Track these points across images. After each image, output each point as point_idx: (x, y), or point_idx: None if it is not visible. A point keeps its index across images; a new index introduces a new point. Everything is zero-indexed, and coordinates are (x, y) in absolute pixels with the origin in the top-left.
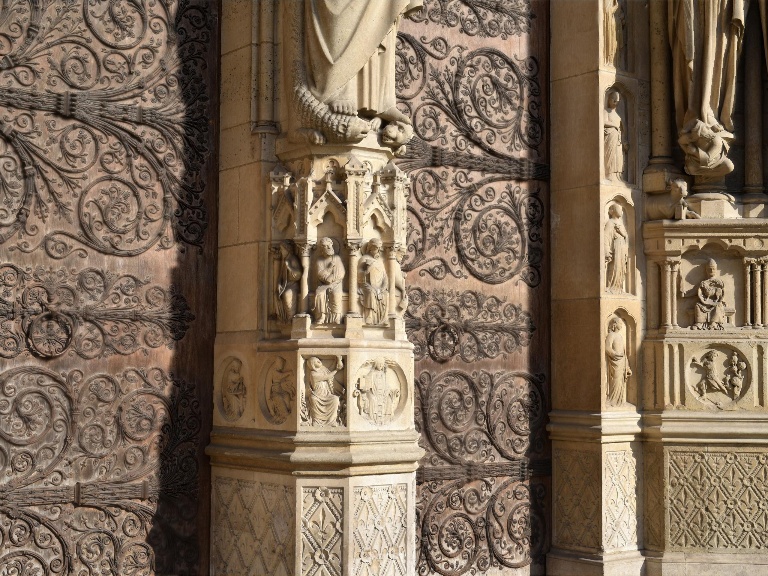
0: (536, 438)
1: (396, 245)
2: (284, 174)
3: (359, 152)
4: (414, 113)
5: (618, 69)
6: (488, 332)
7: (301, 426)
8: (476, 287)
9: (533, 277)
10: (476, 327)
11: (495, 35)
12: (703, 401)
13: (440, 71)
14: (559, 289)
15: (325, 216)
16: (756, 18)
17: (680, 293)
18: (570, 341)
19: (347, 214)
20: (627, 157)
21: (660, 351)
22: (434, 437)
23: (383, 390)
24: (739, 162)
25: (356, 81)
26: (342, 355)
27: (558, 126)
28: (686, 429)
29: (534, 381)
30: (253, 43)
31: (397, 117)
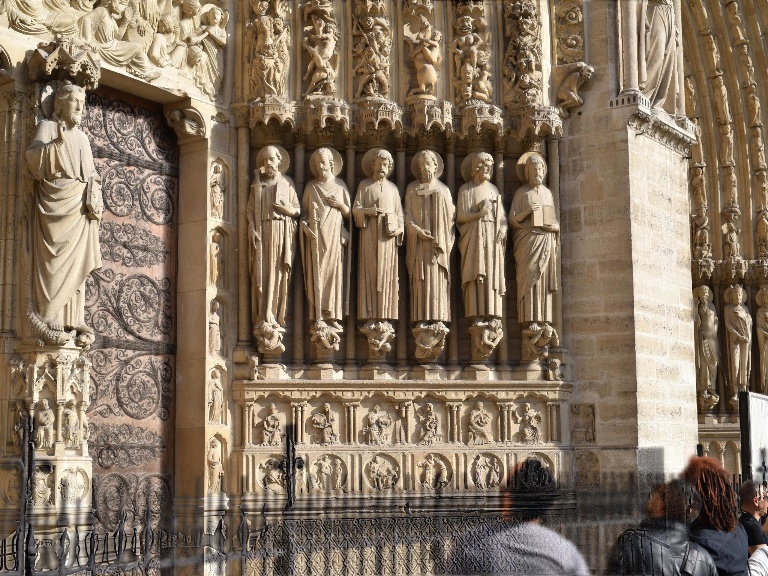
0: (165, 515)
1: (84, 402)
2: (20, 362)
3: (64, 350)
4: (92, 316)
5: (218, 288)
6: (136, 449)
7: (28, 506)
8: (129, 421)
9: (165, 414)
10: (128, 446)
11: (143, 266)
12: (266, 489)
13: (109, 289)
14: (181, 422)
15: (44, 387)
16: (300, 260)
17: (254, 424)
18: (187, 454)
19: (57, 386)
20: (224, 341)
21: (241, 459)
22: (101, 515)
23: (75, 484)
24: (291, 344)
25: (63, 310)
26: (53, 465)
27: (182, 321)
28: (255, 506)
29: (164, 479)
30: (0, 284)
31: (86, 330)
